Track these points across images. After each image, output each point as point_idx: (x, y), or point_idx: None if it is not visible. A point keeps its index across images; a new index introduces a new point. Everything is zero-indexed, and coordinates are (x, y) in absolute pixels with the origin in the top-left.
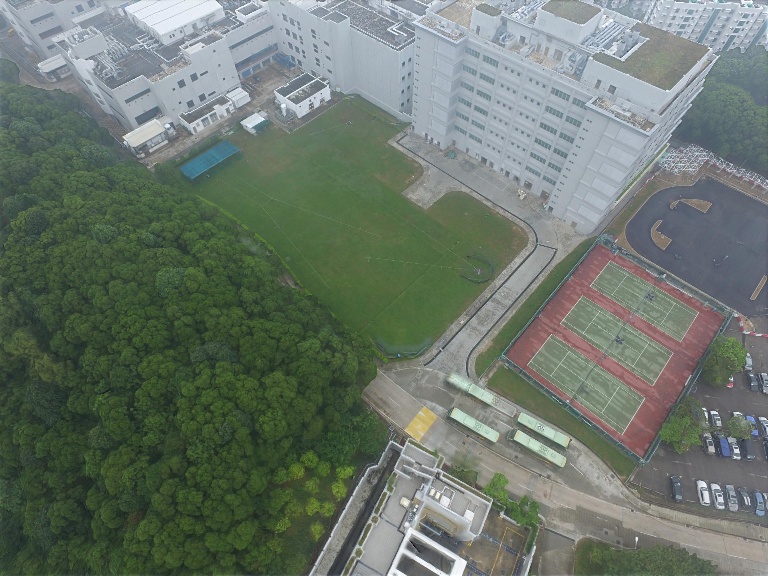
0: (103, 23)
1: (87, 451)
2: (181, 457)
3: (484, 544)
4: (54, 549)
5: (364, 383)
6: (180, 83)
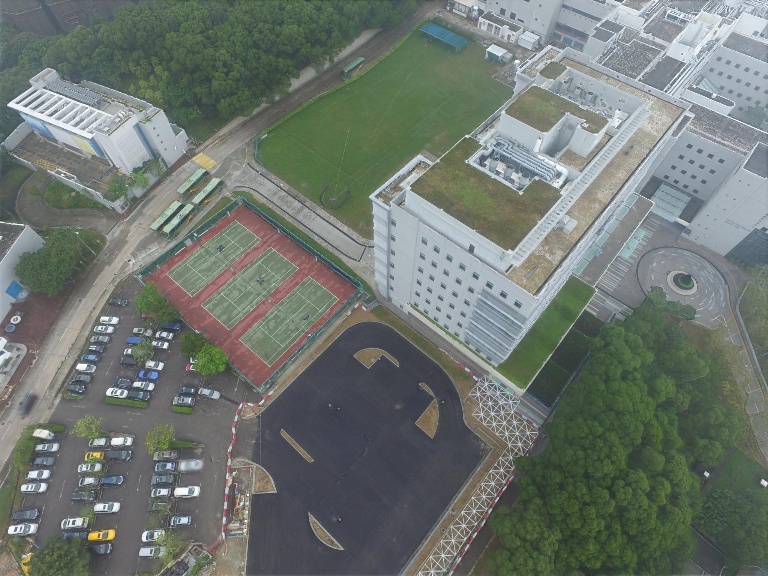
0: None
1: None
2: None
3: None
4: None
5: None
6: None
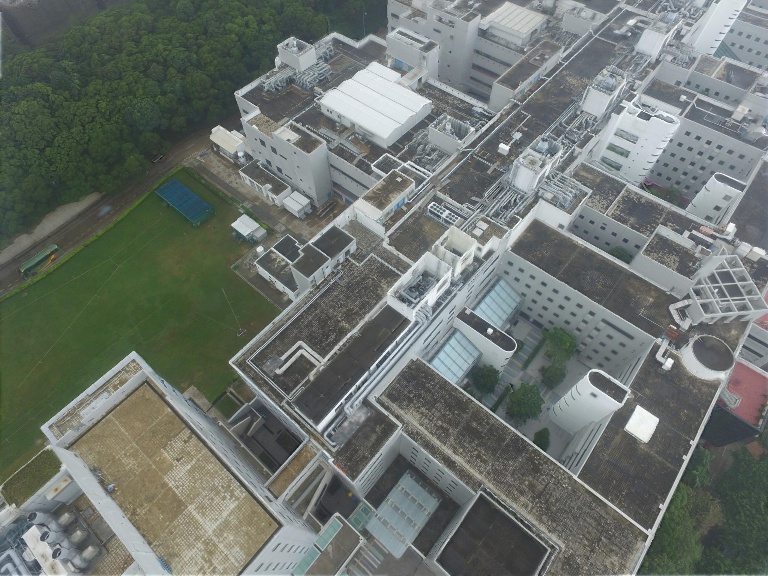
0: (374, 57)
1: None
2: None
3: None
4: None
5: None
6: (262, 141)
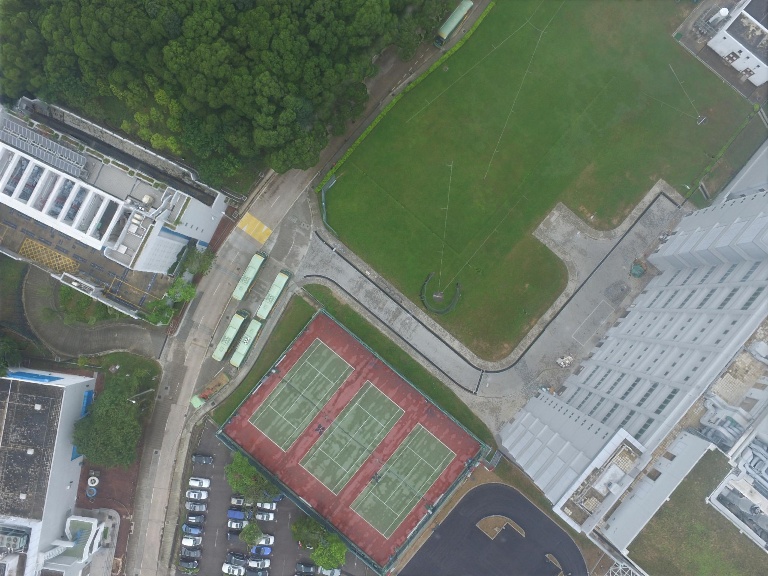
0: None
1: None
2: None
3: (146, 279)
4: None
5: (264, 159)
6: None
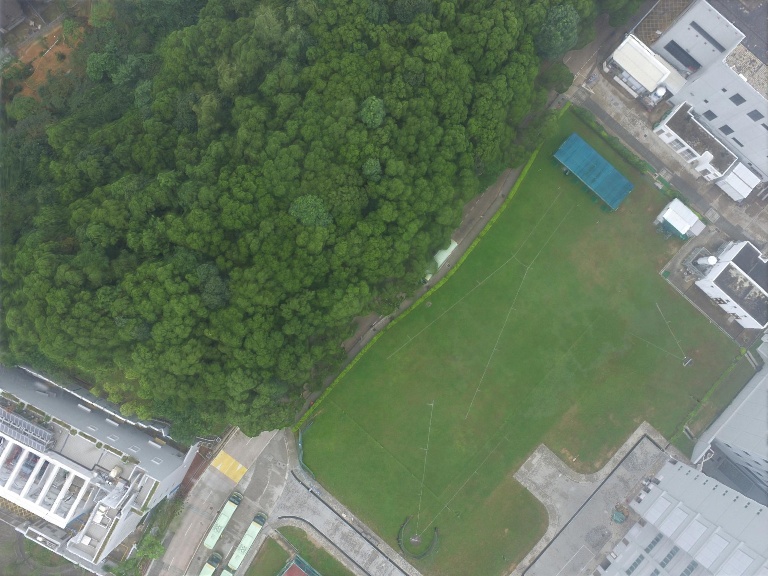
0: None
1: (133, 176)
2: (106, 279)
3: None
4: (72, 168)
5: None
6: (738, 97)
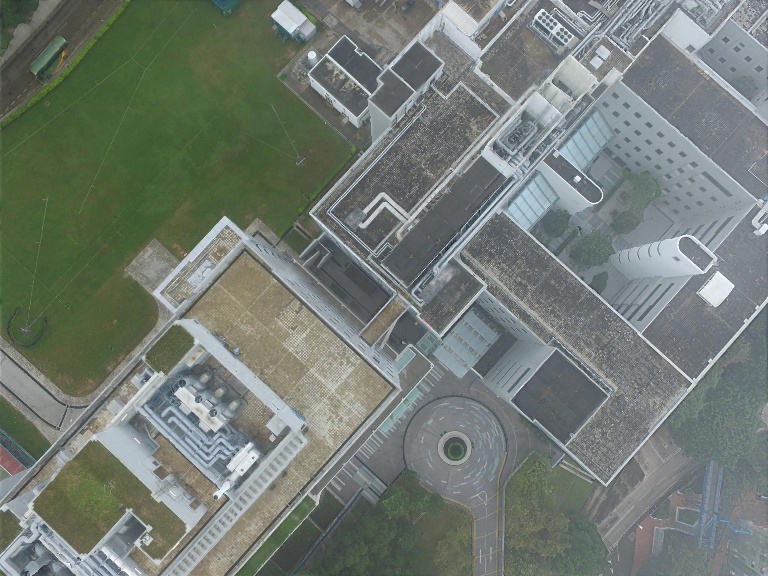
0: None
1: None
2: None
3: None
4: None
5: None
6: None
